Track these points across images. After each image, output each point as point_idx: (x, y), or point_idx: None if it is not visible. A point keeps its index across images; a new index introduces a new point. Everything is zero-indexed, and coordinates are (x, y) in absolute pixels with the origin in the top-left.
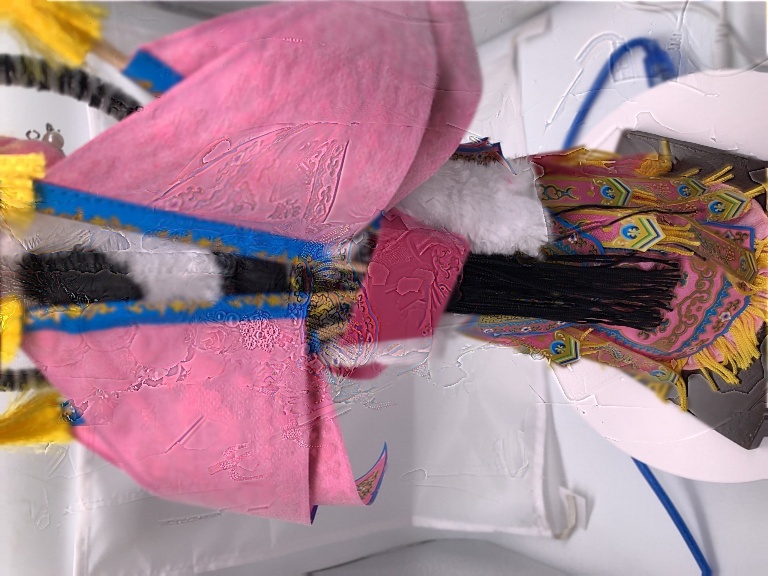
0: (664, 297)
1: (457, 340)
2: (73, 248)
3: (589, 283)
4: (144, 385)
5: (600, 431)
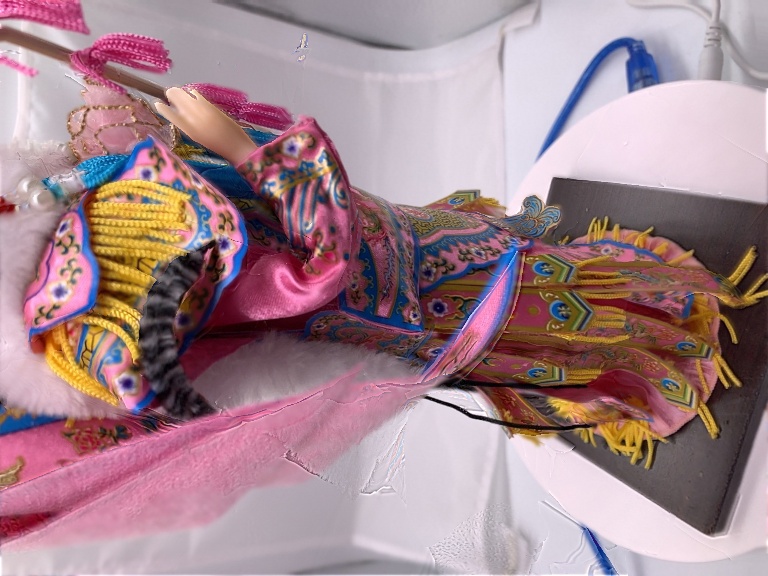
0: None
1: None
2: None
3: None
4: None
5: None
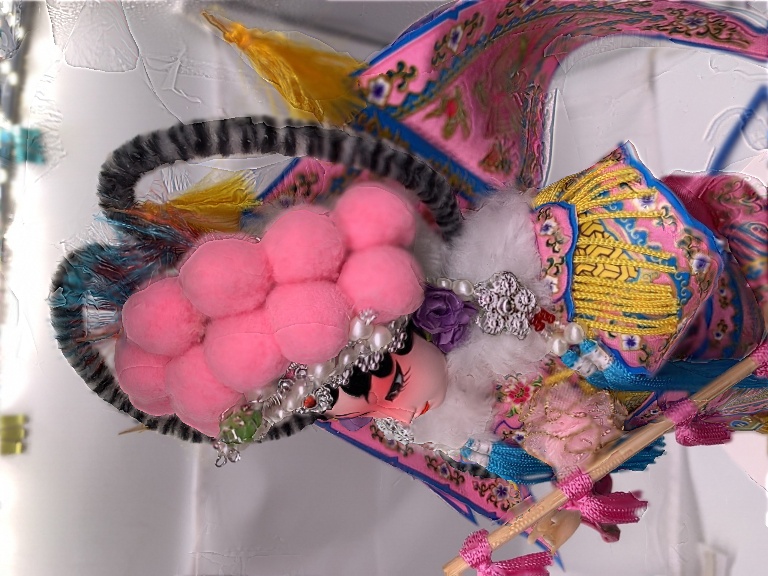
0: None
1: None
2: (232, 196)
3: None
4: (341, 399)
5: None
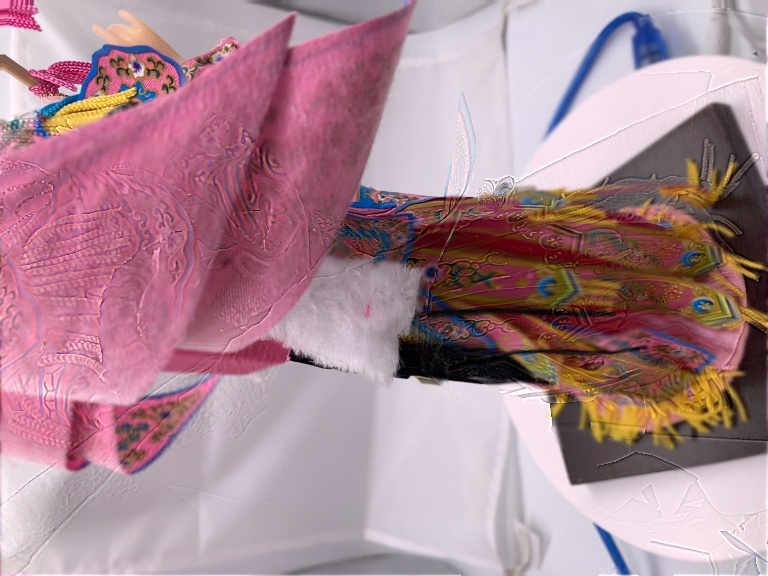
0: None
1: None
2: None
3: None
4: None
5: (729, 23)
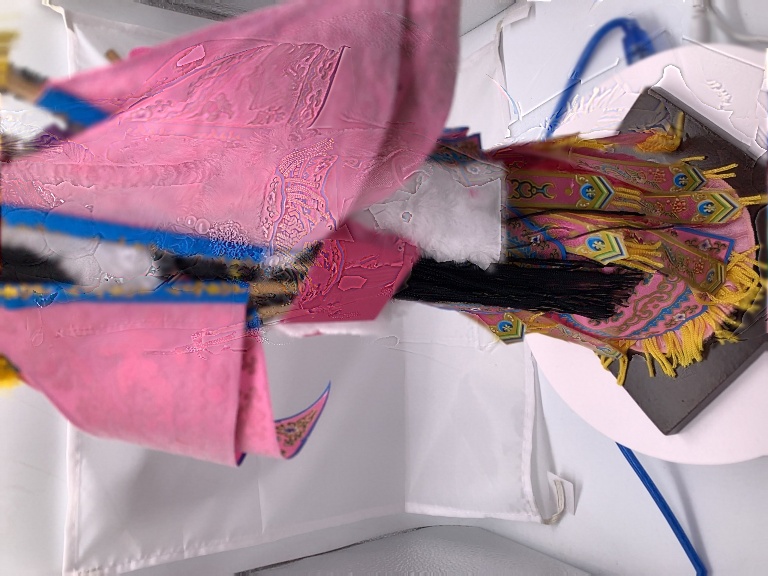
0: (621, 296)
1: None
2: (40, 138)
3: (543, 285)
4: None
5: None
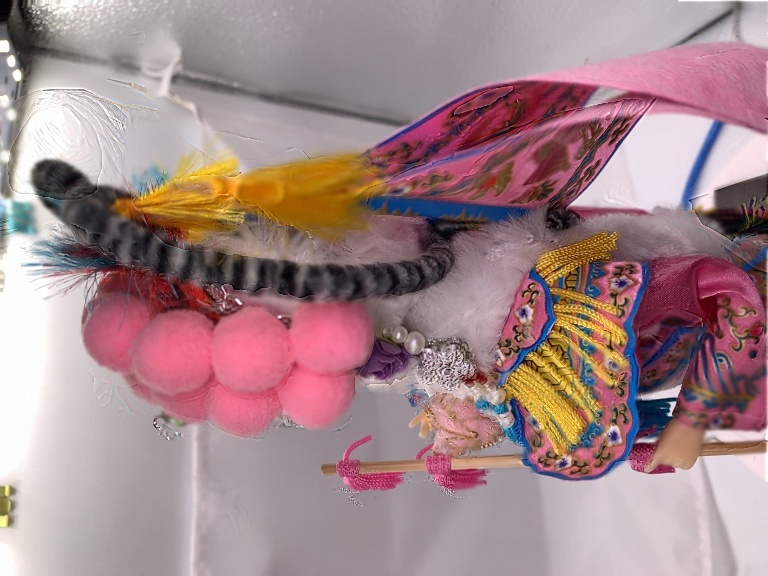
0: None
1: (711, 432)
2: (213, 199)
3: None
4: None
5: (747, 465)
